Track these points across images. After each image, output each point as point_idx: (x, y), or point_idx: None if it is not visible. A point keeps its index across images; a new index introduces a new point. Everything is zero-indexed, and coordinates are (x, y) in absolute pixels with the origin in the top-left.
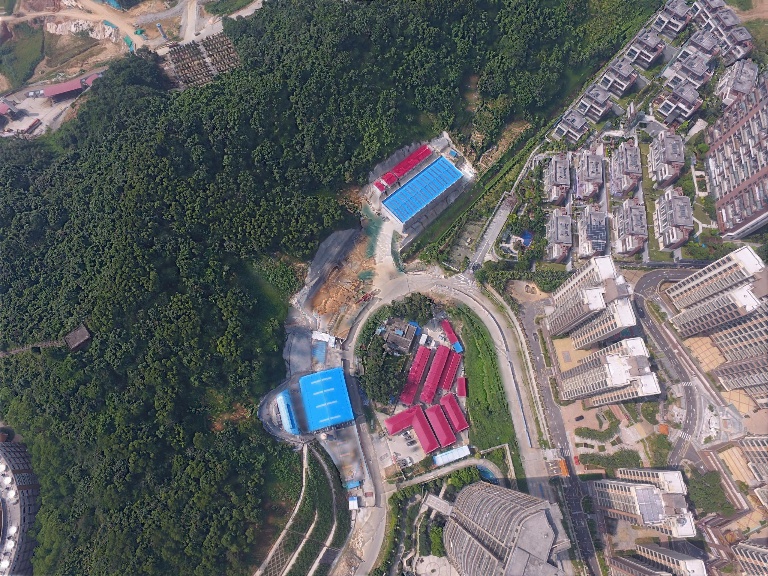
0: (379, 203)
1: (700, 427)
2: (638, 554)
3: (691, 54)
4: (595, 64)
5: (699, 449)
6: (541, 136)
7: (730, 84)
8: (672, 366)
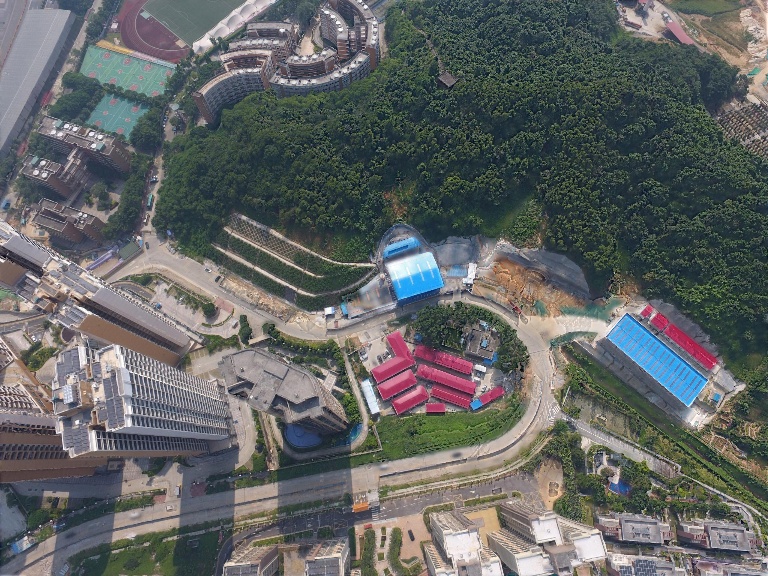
0: None
1: None
2: None
3: None
4: None
5: None
6: None
7: None
8: None
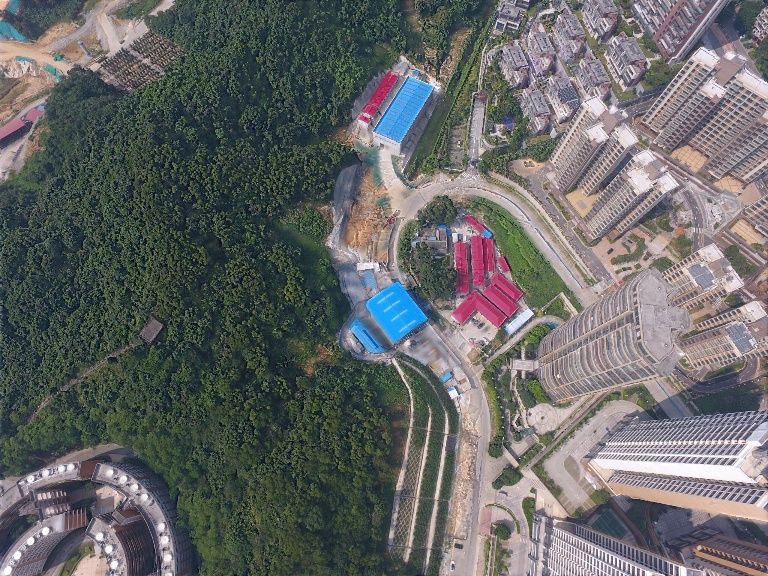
0: (369, 135)
1: (706, 219)
2: (700, 331)
3: None
4: None
5: (713, 235)
6: (485, 35)
7: None
8: None
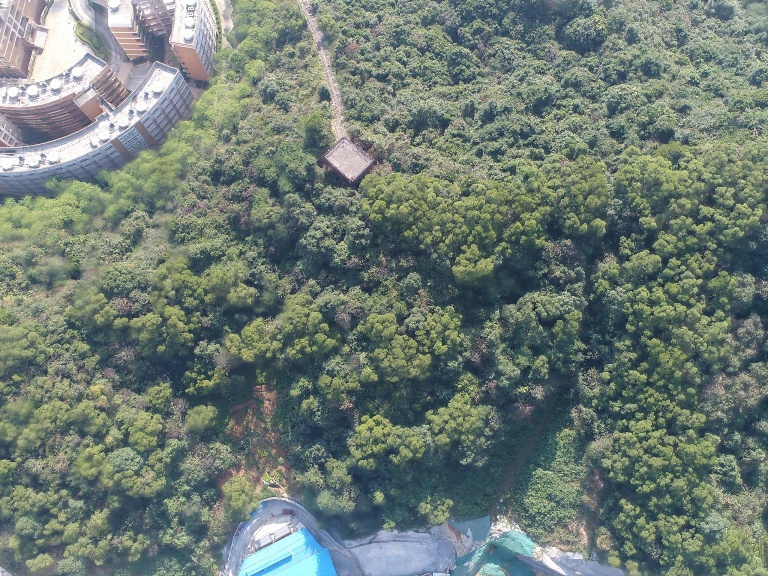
0: None
1: None
2: None
3: None
4: None
5: None
6: None
7: None
8: None
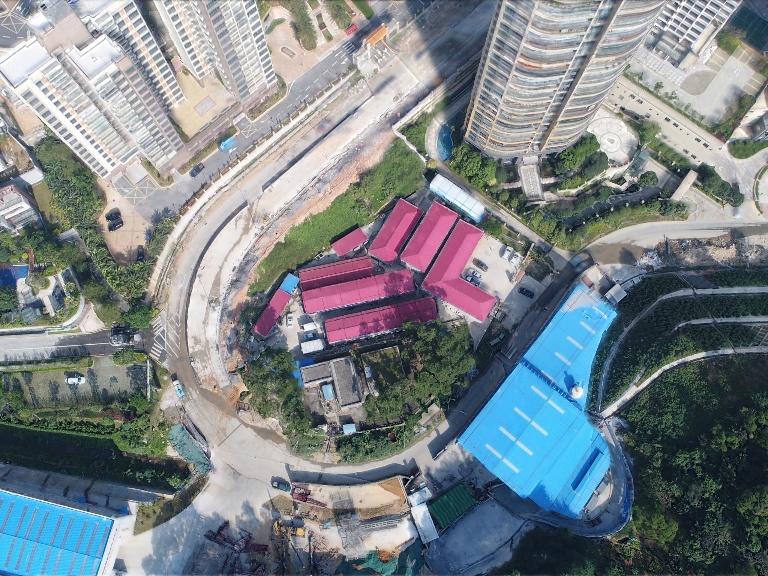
0: None
1: None
2: None
3: None
4: None
5: None
6: None
7: None
8: None
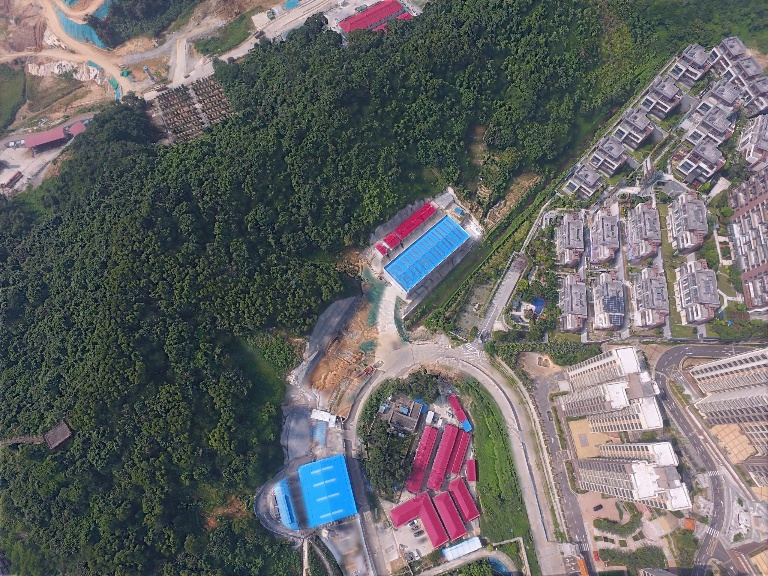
0: (381, 267)
1: (729, 522)
2: None
3: (711, 106)
4: (607, 111)
5: (728, 548)
6: (551, 191)
7: (754, 141)
8: (697, 454)
